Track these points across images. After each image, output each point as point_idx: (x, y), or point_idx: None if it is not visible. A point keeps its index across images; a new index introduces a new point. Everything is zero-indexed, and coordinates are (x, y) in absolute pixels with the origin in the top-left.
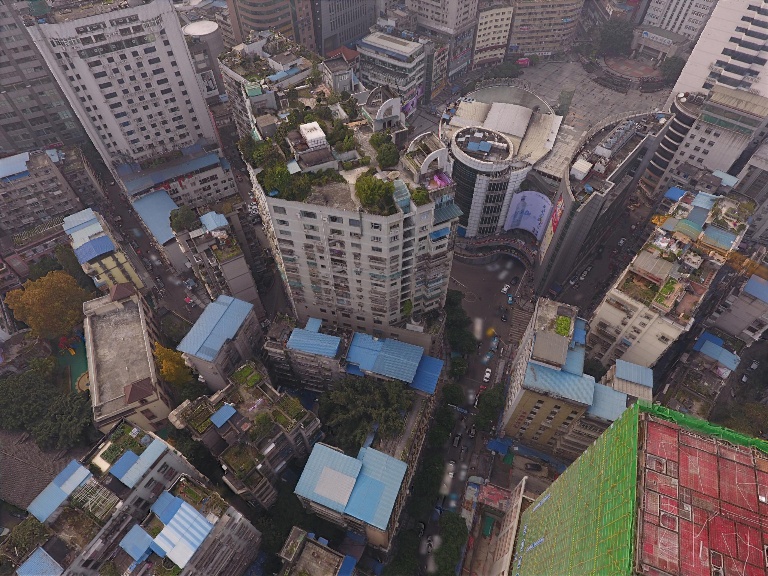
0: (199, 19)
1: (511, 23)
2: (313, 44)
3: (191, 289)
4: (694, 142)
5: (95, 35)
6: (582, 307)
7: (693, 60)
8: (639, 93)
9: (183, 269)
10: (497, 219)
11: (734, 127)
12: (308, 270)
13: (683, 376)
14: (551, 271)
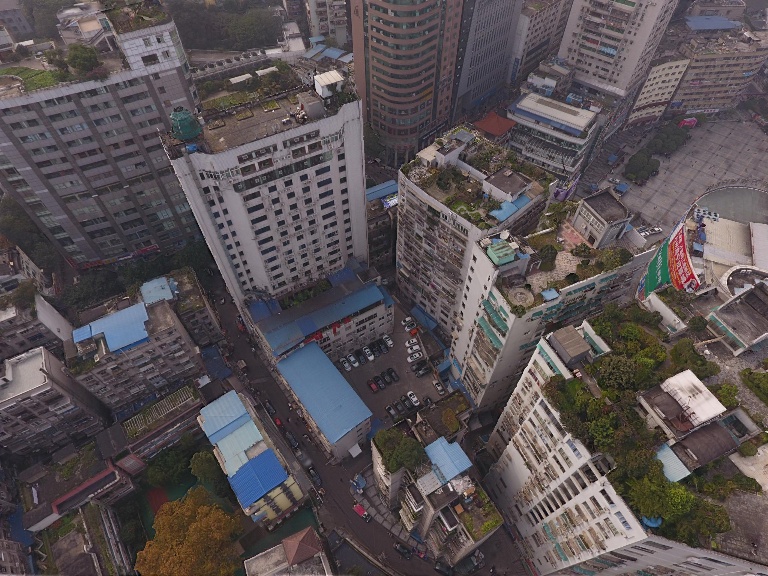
0: None
1: (681, 77)
2: (448, 105)
3: (362, 492)
4: None
5: (260, 161)
6: None
7: None
8: None
9: (344, 455)
10: None
11: None
12: (626, 572)
13: None
14: None
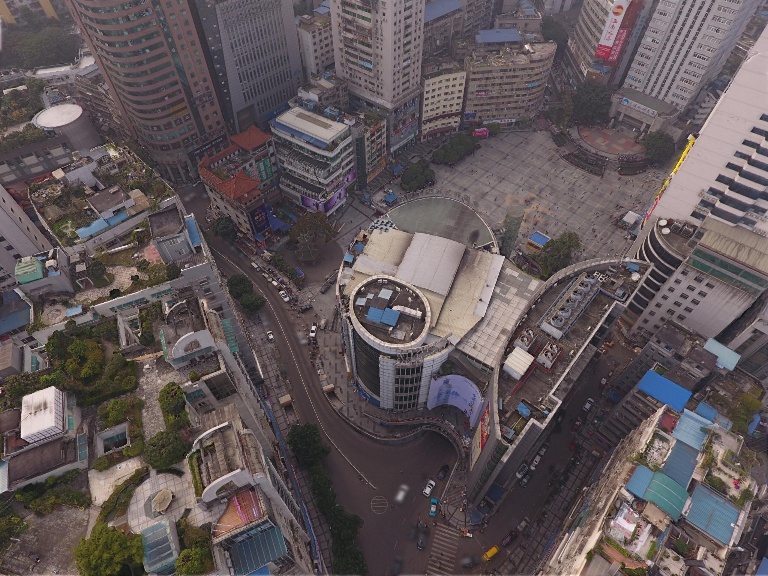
0: (62, 101)
1: (465, 89)
2: (220, 120)
3: None
4: (680, 288)
5: None
6: (530, 519)
7: (678, 182)
8: (617, 175)
9: None
10: (417, 396)
11: (733, 281)
12: None
13: None
14: (480, 497)
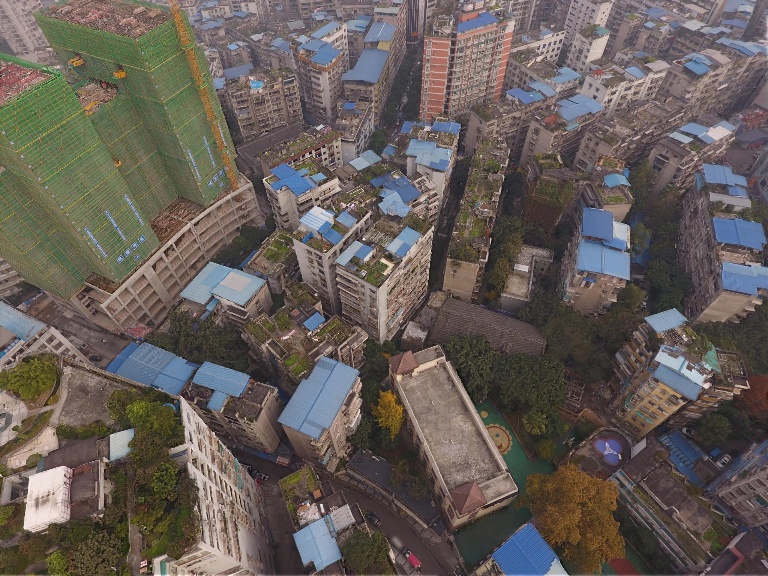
0: None
1: None
2: None
3: None
4: None
5: None
6: None
7: None
8: None
9: None
10: None
11: None
12: None
13: None
14: None
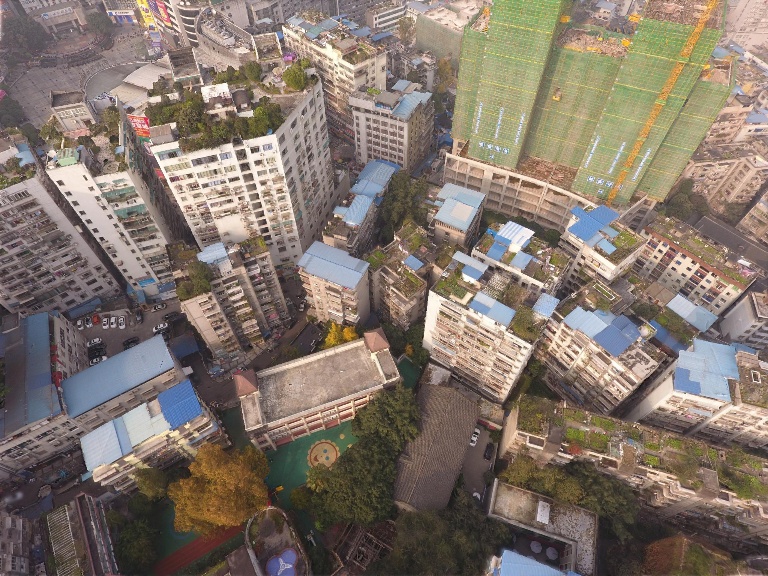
0: None
1: None
2: None
3: (224, 370)
4: None
5: None
6: None
7: None
8: (108, 51)
9: None
10: None
11: None
12: (301, 189)
13: (391, 89)
14: None
